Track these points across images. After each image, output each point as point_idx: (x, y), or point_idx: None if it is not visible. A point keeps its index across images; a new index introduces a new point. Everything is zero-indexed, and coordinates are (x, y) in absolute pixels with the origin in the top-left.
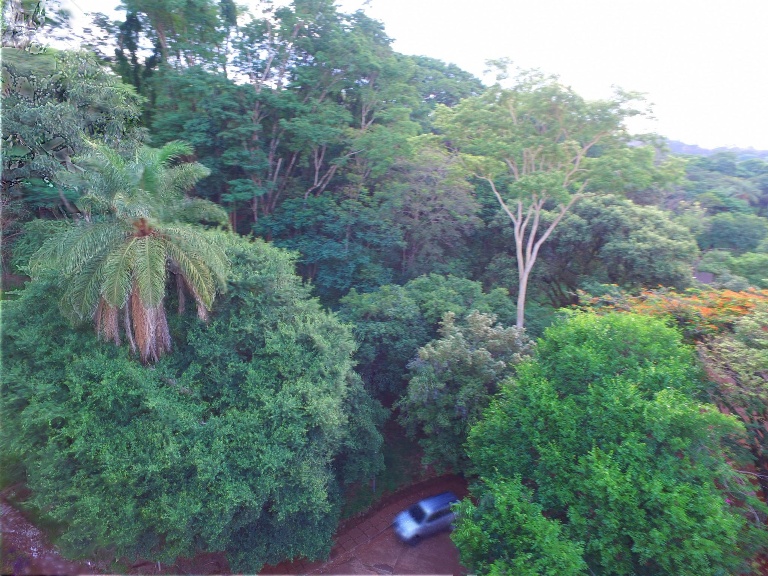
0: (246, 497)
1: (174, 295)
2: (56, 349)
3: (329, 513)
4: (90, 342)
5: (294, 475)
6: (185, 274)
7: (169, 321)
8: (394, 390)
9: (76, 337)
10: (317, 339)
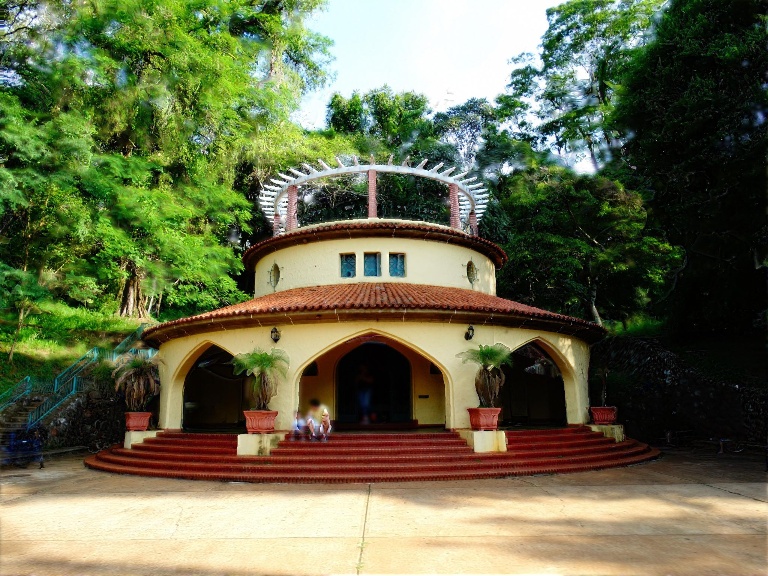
0: None
1: None
2: None
3: None
4: None
5: None
6: None
7: None
8: None
9: None
10: None
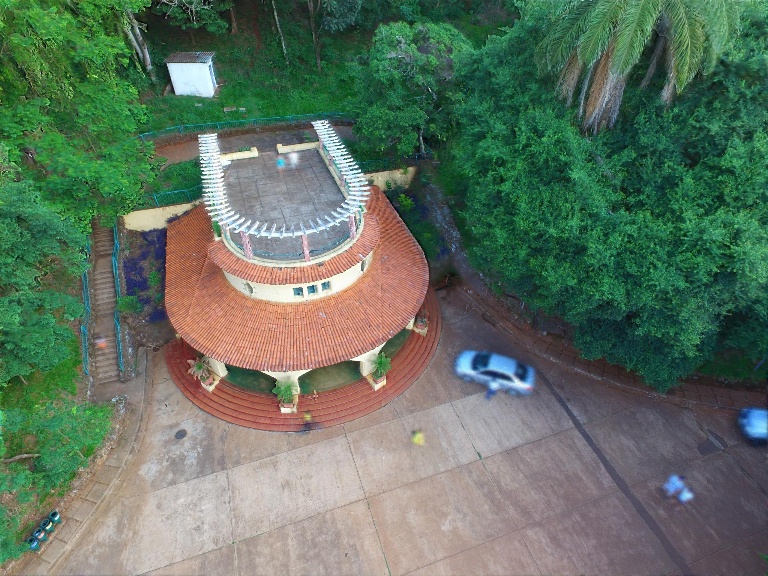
0: (618, 297)
1: (645, 63)
2: (518, 95)
3: (689, 358)
4: (546, 96)
5: (675, 305)
6: (672, 38)
7: (626, 93)
8: None
9: (537, 87)
10: None
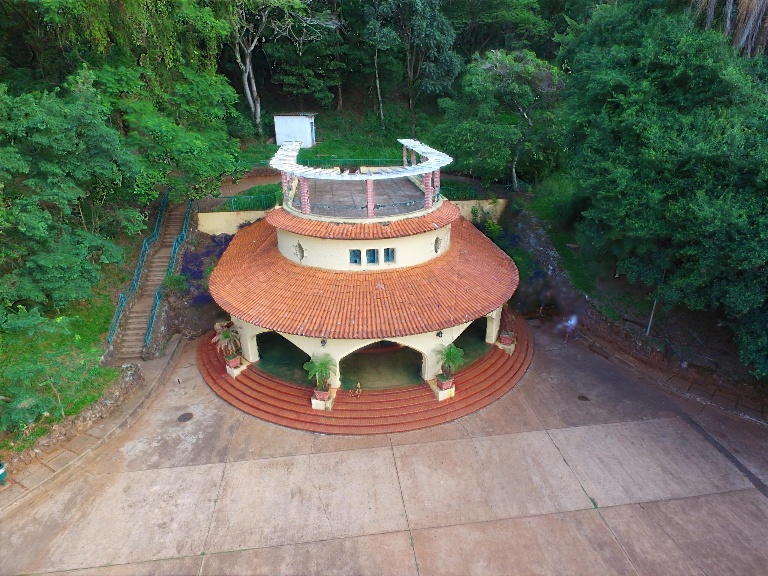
0: None
1: None
2: None
3: None
4: (677, 18)
5: None
6: None
7: None
8: None
9: (664, 12)
10: None
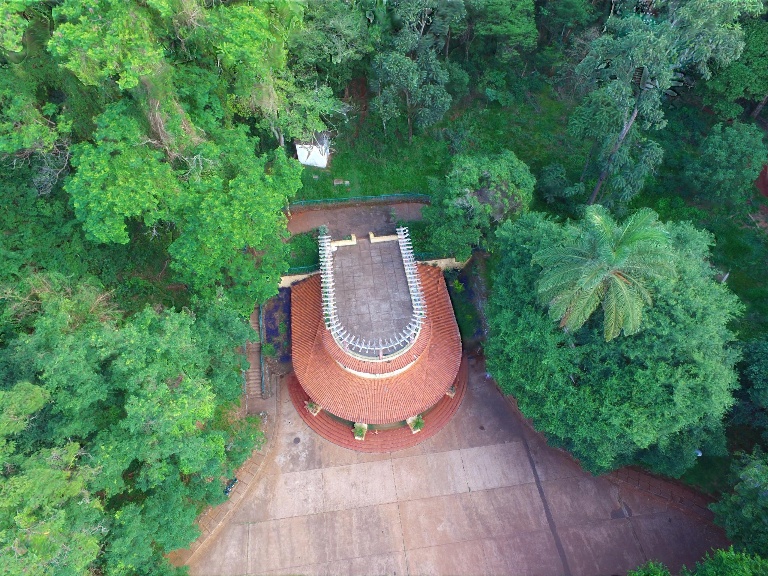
0: (558, 435)
1: None
2: (527, 290)
3: (615, 461)
4: None
5: (596, 443)
6: (605, 318)
7: None
8: (765, 437)
9: None
10: (674, 399)
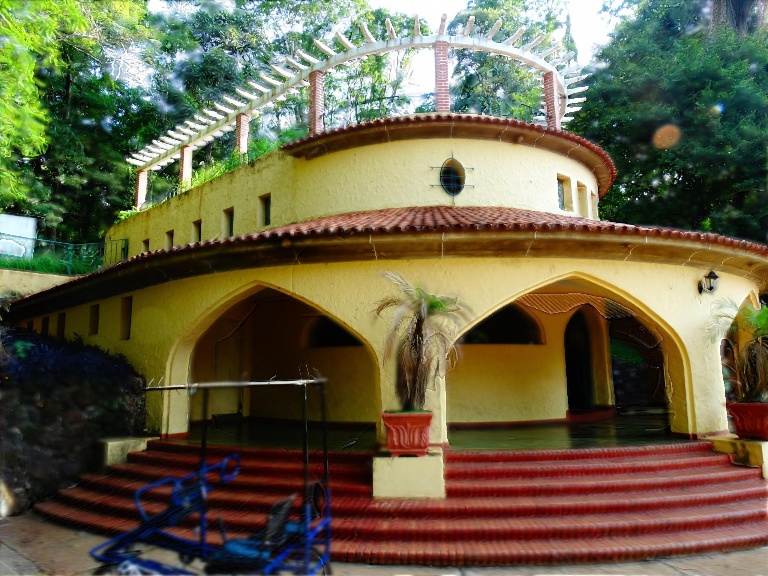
0: None
1: None
2: None
3: None
4: None
5: None
6: None
7: None
8: None
9: None
10: None
